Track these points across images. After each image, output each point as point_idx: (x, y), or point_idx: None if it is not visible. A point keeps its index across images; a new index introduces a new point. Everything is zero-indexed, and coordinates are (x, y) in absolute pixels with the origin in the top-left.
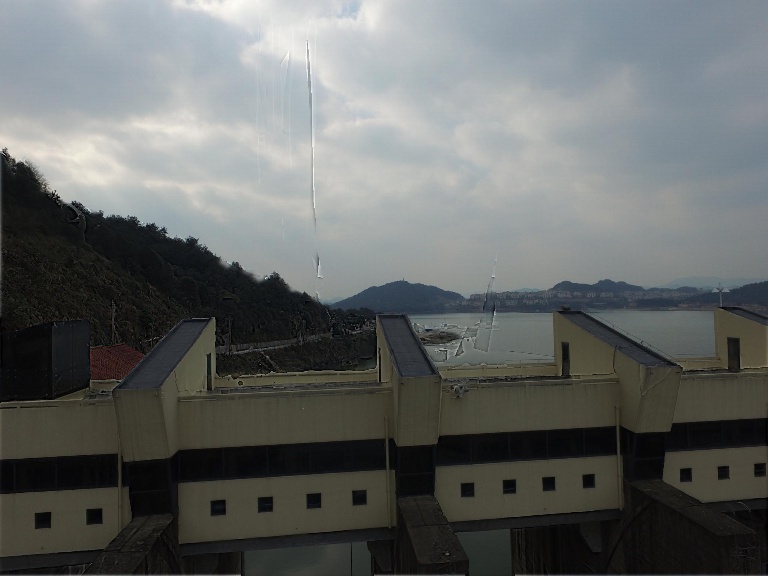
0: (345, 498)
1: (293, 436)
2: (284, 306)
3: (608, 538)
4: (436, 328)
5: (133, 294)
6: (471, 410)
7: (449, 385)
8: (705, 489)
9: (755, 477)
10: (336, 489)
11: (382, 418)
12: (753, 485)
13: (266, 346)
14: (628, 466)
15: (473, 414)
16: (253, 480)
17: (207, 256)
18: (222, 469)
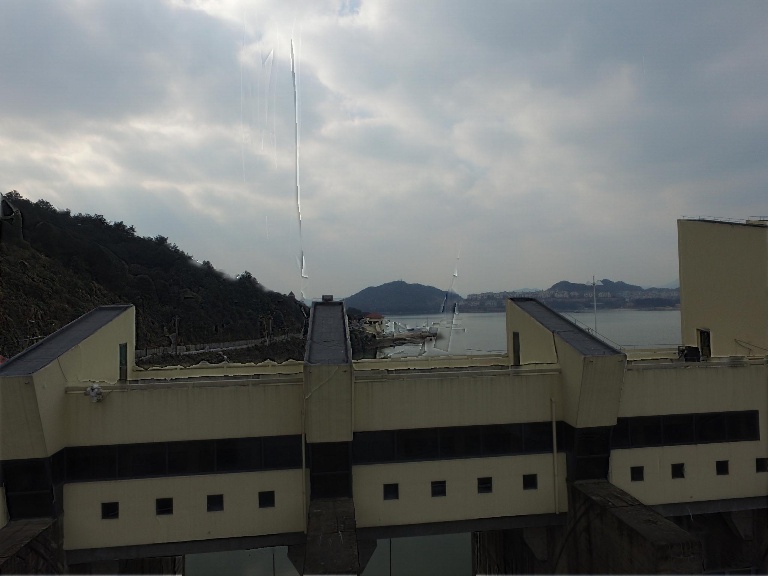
0: None
1: None
2: (253, 305)
3: None
4: (418, 328)
5: (70, 292)
6: (117, 416)
7: (89, 386)
8: (415, 508)
9: (478, 493)
10: None
11: None
12: (476, 503)
13: (230, 346)
14: None
15: (120, 421)
16: None
17: (174, 255)
18: None
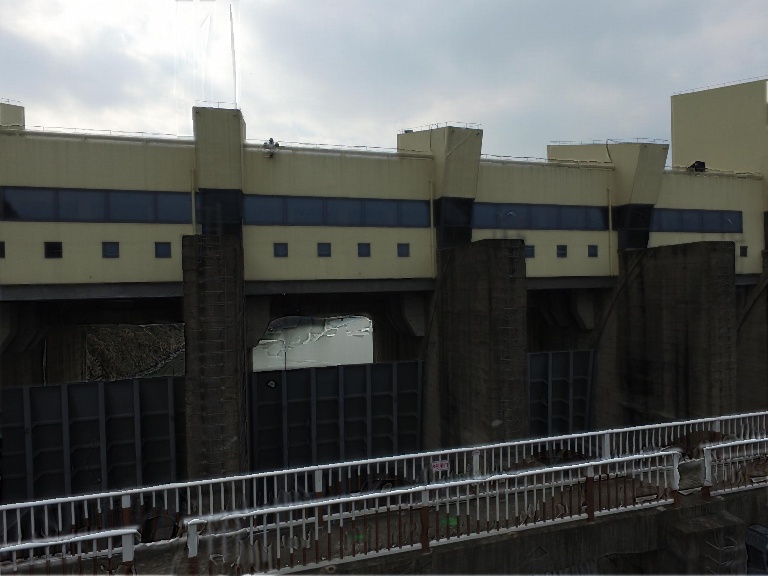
0: (147, 249)
1: (86, 181)
2: None
3: (428, 317)
4: None
5: None
6: (285, 172)
7: (262, 144)
8: None
9: (557, 257)
10: (136, 239)
11: (188, 171)
12: (555, 264)
13: None
14: (440, 237)
15: (287, 176)
16: (38, 223)
17: None
18: (0, 209)
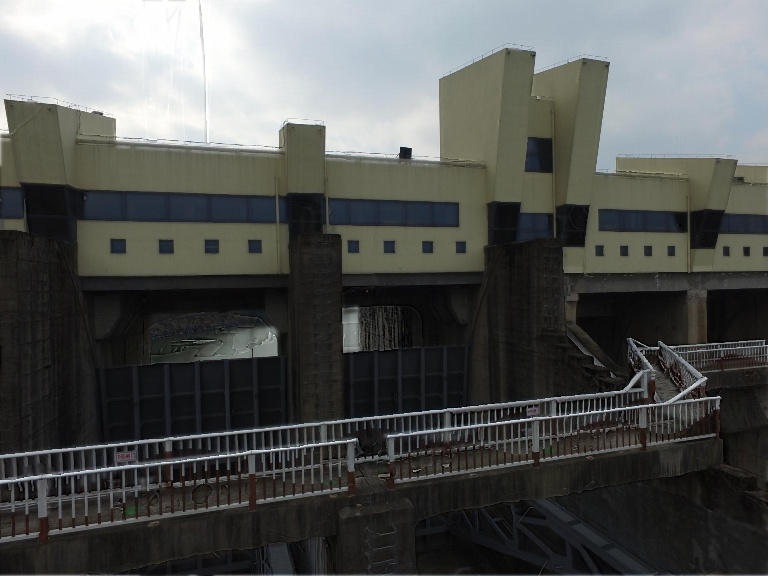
0: None
1: None
2: None
3: None
4: None
5: None
6: None
7: None
8: (143, 262)
9: (206, 253)
10: None
11: None
12: (203, 261)
13: None
14: None
15: None
16: None
17: None
18: None
